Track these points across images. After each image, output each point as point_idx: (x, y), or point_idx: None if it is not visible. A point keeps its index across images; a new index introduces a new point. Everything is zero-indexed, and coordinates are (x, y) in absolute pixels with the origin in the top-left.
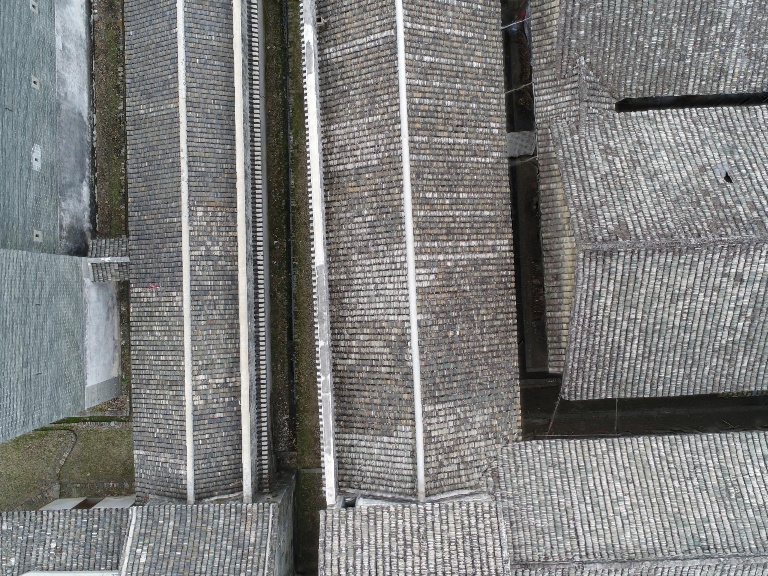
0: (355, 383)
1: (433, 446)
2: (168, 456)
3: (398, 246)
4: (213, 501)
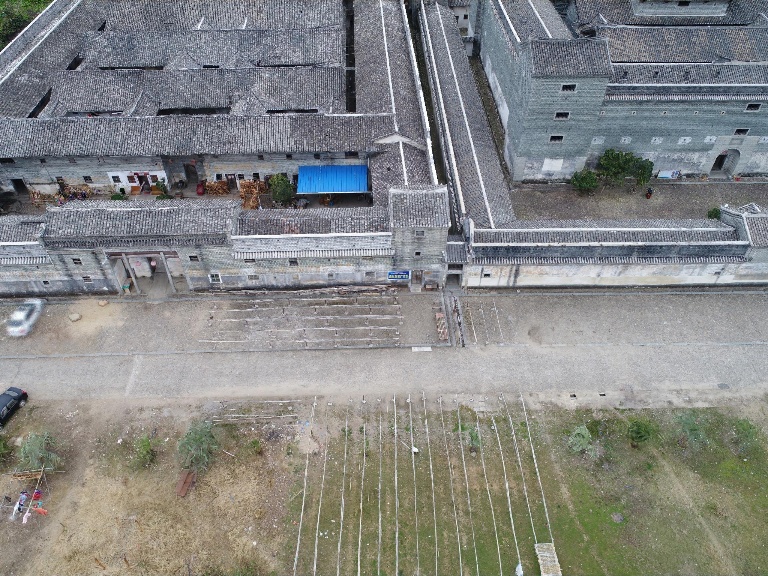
0: (395, 1)
1: None
2: (444, 9)
3: (384, 7)
4: (431, 3)
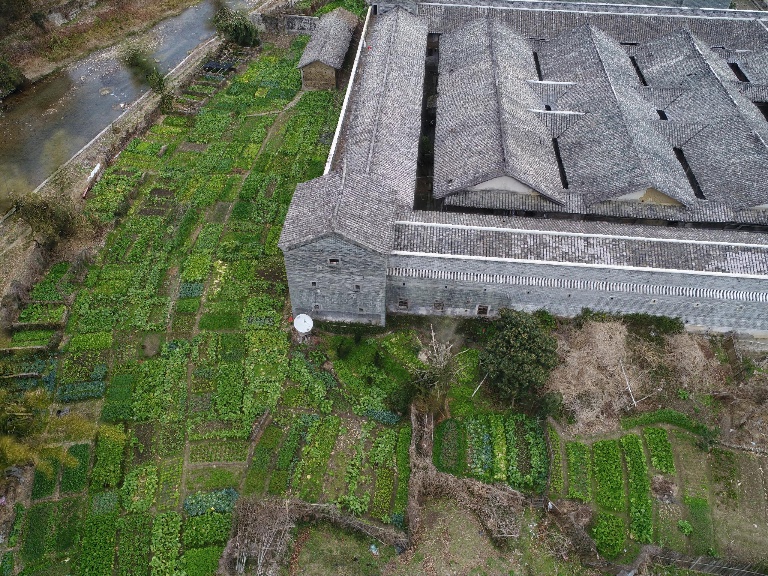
0: None
1: (432, 8)
2: None
3: None
4: None
